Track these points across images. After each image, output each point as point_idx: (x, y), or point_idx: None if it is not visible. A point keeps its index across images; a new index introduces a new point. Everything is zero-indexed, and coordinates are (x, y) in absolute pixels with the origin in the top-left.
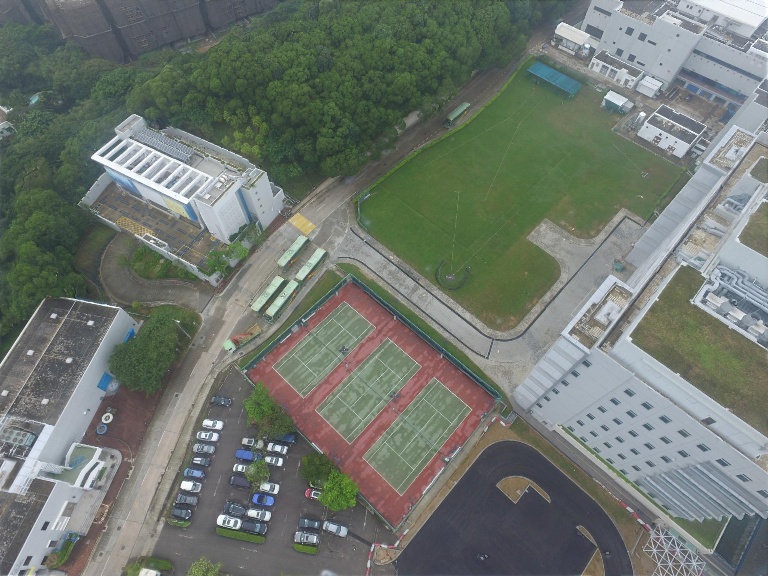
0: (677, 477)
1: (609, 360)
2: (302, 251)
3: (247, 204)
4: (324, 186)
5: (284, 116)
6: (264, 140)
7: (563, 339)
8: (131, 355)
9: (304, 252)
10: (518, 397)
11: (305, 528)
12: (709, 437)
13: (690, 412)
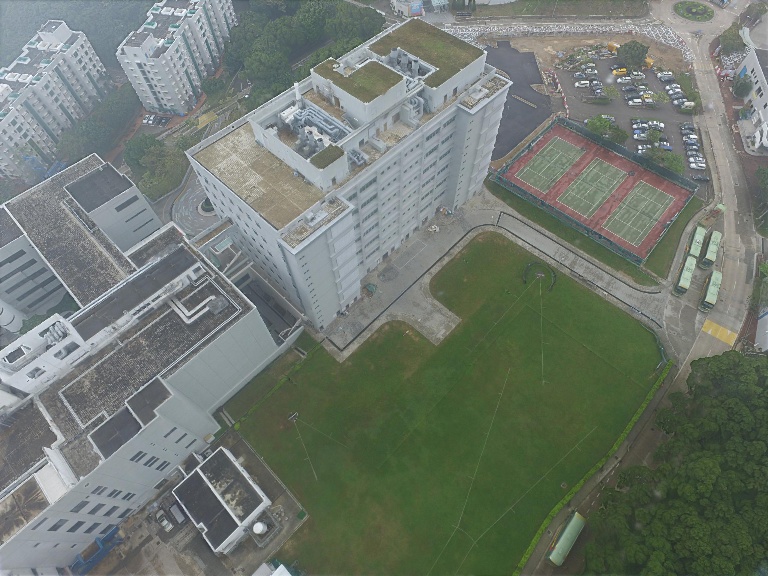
0: None
1: None
2: None
3: None
4: None
5: None
6: None
7: None
8: None
9: None
10: None
11: None
12: None
13: None
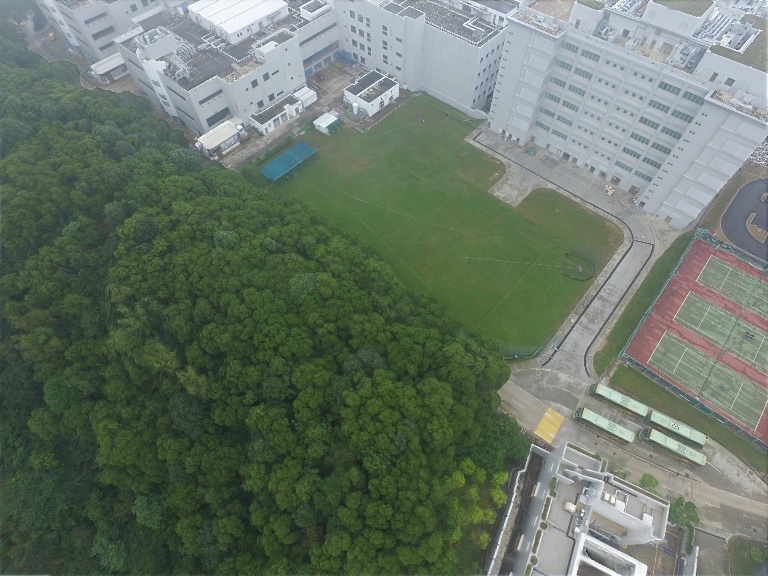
0: None
1: None
2: None
3: None
4: None
5: None
6: None
7: None
8: None
9: None
10: None
11: None
12: None
13: None
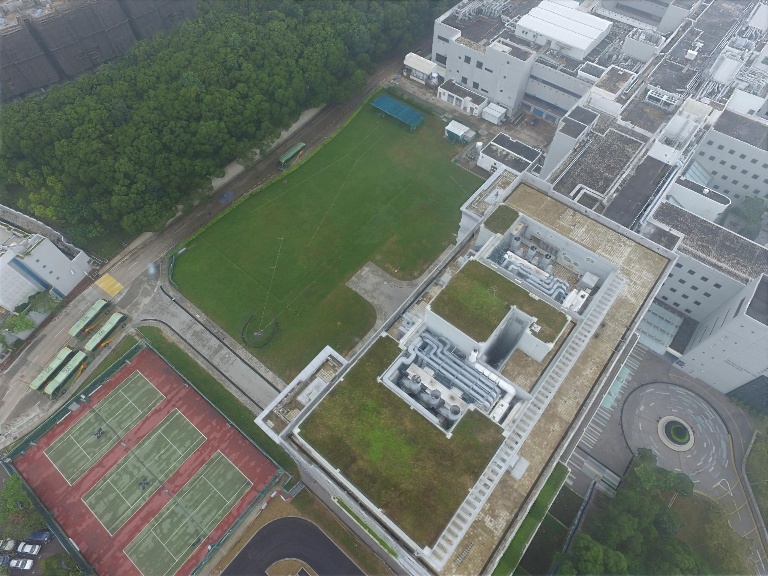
0: None
1: (291, 451)
2: (102, 316)
3: (33, 272)
4: (139, 242)
5: (73, 176)
6: (61, 200)
7: None
8: None
9: (106, 317)
10: None
11: None
12: None
13: None
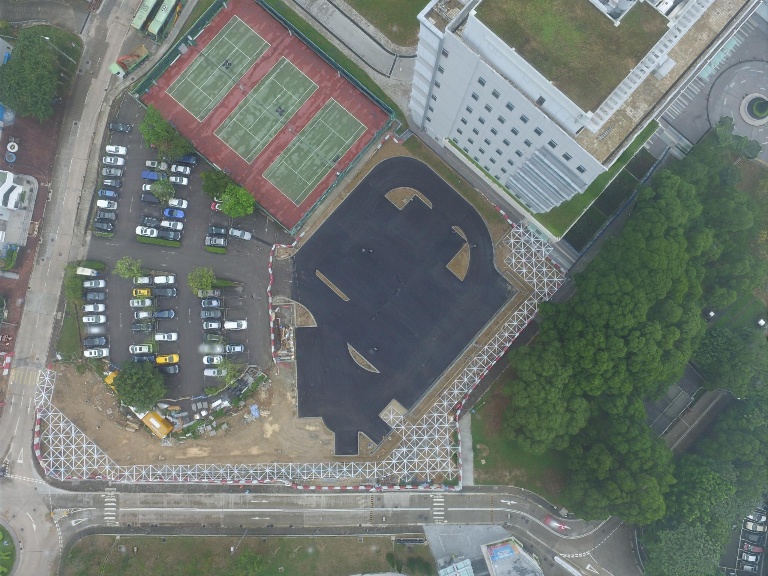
0: (526, 169)
1: (458, 42)
2: None
3: None
4: None
5: None
6: None
7: (421, 25)
8: (8, 77)
9: None
10: (413, 114)
11: (213, 234)
12: (539, 117)
13: (527, 94)
